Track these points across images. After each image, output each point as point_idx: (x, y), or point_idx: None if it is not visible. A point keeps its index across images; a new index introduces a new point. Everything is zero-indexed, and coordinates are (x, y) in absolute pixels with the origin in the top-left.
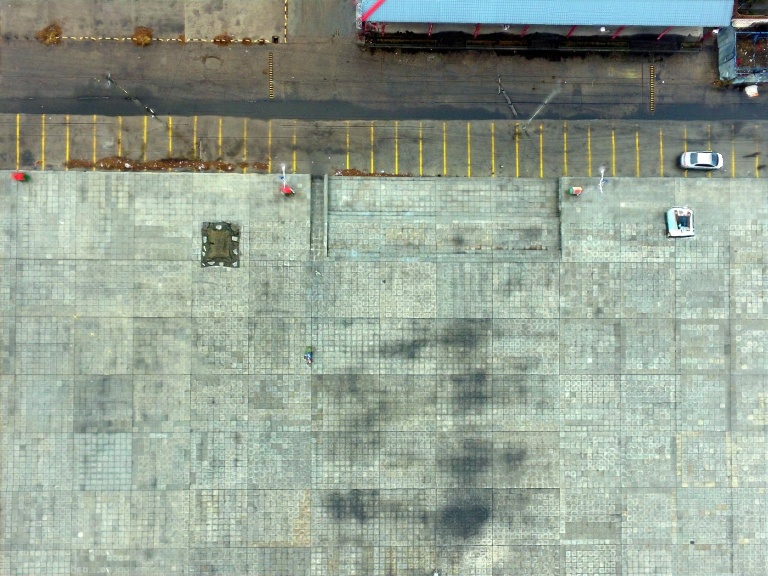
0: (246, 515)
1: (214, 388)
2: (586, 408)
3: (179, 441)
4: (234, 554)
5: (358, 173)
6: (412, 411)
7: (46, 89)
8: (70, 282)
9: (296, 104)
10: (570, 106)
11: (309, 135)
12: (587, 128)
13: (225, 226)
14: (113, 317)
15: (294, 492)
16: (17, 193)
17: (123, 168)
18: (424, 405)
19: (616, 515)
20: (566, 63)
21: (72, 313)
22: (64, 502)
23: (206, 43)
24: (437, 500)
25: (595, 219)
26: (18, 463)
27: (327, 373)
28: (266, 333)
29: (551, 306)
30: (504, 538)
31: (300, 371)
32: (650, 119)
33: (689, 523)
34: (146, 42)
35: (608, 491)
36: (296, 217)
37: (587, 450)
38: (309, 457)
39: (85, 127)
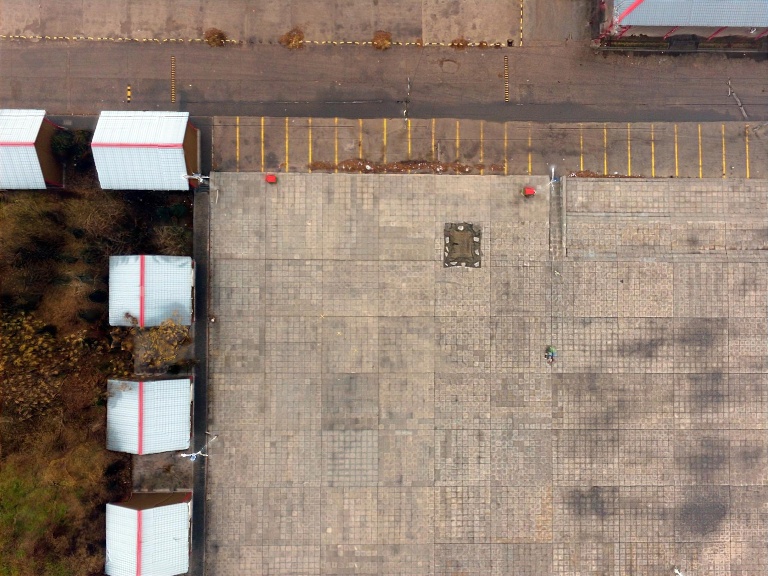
0: (489, 511)
1: (457, 386)
2: None
3: (424, 438)
4: (478, 550)
5: (592, 174)
6: (650, 409)
7: (289, 92)
8: (317, 282)
9: (531, 107)
10: None
11: (544, 137)
12: None
13: (467, 227)
14: (359, 316)
15: (536, 489)
16: (266, 195)
17: (364, 170)
18: (662, 403)
19: None
20: None
21: (319, 312)
22: (313, 498)
23: (443, 47)
24: (676, 497)
25: None
26: (269, 460)
27: (567, 372)
28: (507, 332)
29: None
30: (742, 535)
31: (541, 370)
32: None
33: None
34: (386, 46)
35: None
36: (536, 218)
37: None
38: (550, 454)
39: (327, 130)
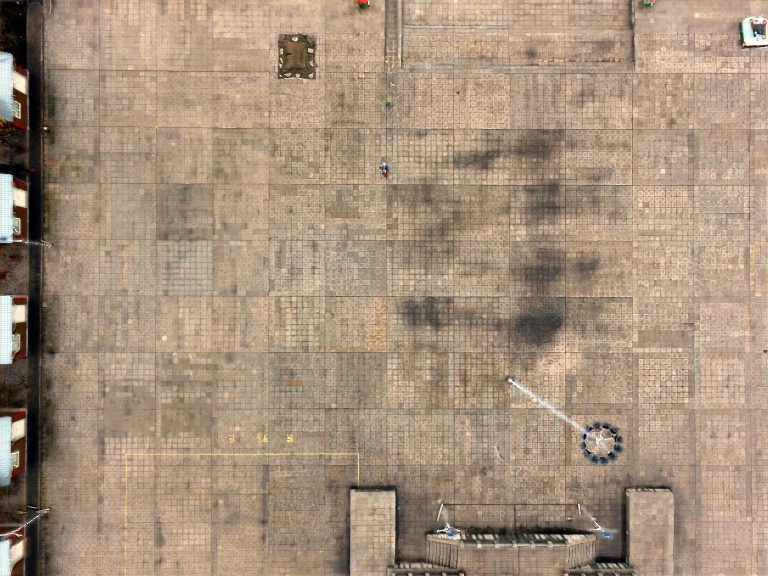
0: (324, 321)
1: (292, 197)
2: (659, 218)
3: (258, 249)
4: (312, 359)
5: None
6: (486, 221)
7: None
8: (151, 93)
9: None
10: None
11: None
12: None
13: (301, 38)
14: (193, 128)
15: (370, 299)
16: (99, 6)
17: None
18: (498, 215)
19: (689, 324)
20: None
21: (154, 123)
22: (148, 307)
23: None
24: (511, 308)
25: (669, 30)
26: (104, 268)
27: (402, 183)
28: (342, 144)
29: (624, 117)
30: (577, 346)
31: (375, 181)
32: None
33: (762, 332)
34: None
35: (681, 300)
36: (371, 29)
37: (660, 260)
38: (385, 265)
39: None
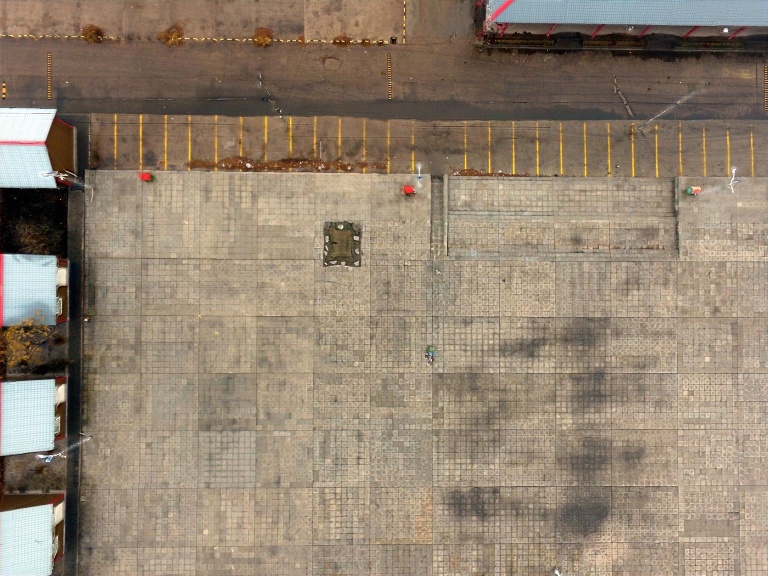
0: (369, 513)
1: (336, 386)
2: (704, 406)
3: (302, 439)
4: (357, 551)
5: (476, 173)
6: (532, 409)
7: (168, 90)
8: (194, 281)
9: (414, 104)
10: (685, 106)
11: (427, 135)
12: (702, 128)
13: (347, 226)
14: (237, 316)
15: (416, 490)
16: (142, 193)
17: (244, 168)
18: (544, 403)
19: (734, 513)
20: (681, 63)
21: (196, 312)
22: (189, 500)
23: (325, 44)
24: (557, 498)
25: (712, 219)
26: (144, 461)
27: (448, 372)
28: (387, 332)
29: (669, 305)
30: (623, 536)
31: (421, 370)
32: (764, 119)
33: None
34: (267, 43)
35: (726, 489)
36: (417, 217)
37: (705, 448)
38: (430, 455)
39: (207, 127)
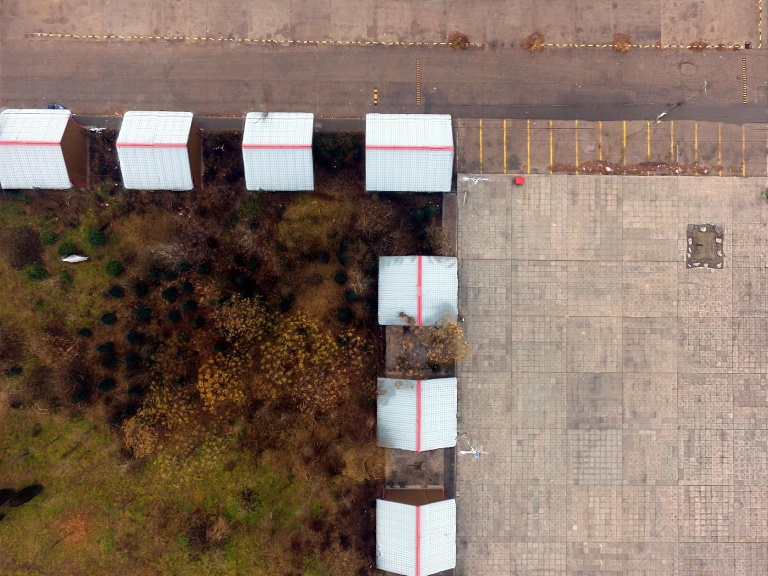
0: (733, 511)
1: (700, 386)
2: None
3: (667, 438)
4: (722, 549)
5: None
6: None
7: (531, 95)
8: (562, 282)
9: None
10: None
11: None
12: None
13: (709, 228)
14: (603, 317)
15: None
16: (512, 196)
17: (604, 171)
18: None
19: None
20: None
21: (564, 312)
22: (559, 496)
23: (682, 49)
24: None
25: None
26: (515, 458)
27: None
28: (749, 333)
29: None
30: None
31: None
32: None
33: None
34: (627, 49)
35: None
36: None
37: None
38: None
39: (567, 132)
